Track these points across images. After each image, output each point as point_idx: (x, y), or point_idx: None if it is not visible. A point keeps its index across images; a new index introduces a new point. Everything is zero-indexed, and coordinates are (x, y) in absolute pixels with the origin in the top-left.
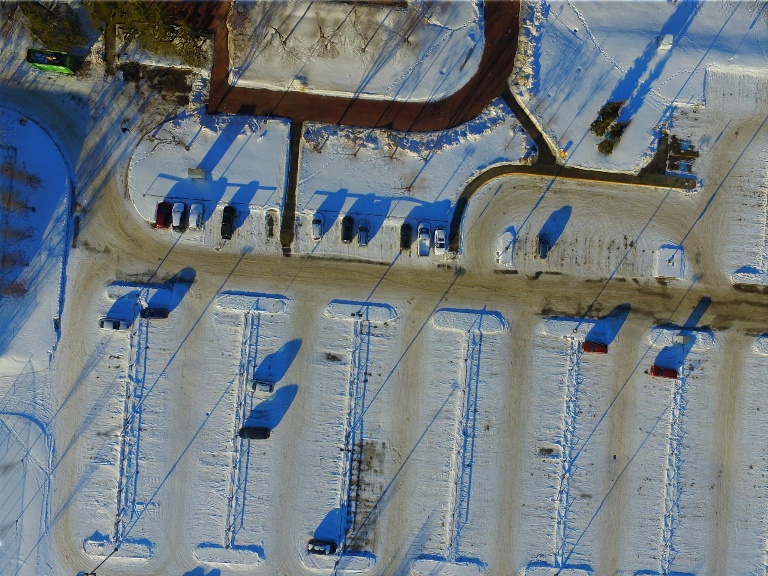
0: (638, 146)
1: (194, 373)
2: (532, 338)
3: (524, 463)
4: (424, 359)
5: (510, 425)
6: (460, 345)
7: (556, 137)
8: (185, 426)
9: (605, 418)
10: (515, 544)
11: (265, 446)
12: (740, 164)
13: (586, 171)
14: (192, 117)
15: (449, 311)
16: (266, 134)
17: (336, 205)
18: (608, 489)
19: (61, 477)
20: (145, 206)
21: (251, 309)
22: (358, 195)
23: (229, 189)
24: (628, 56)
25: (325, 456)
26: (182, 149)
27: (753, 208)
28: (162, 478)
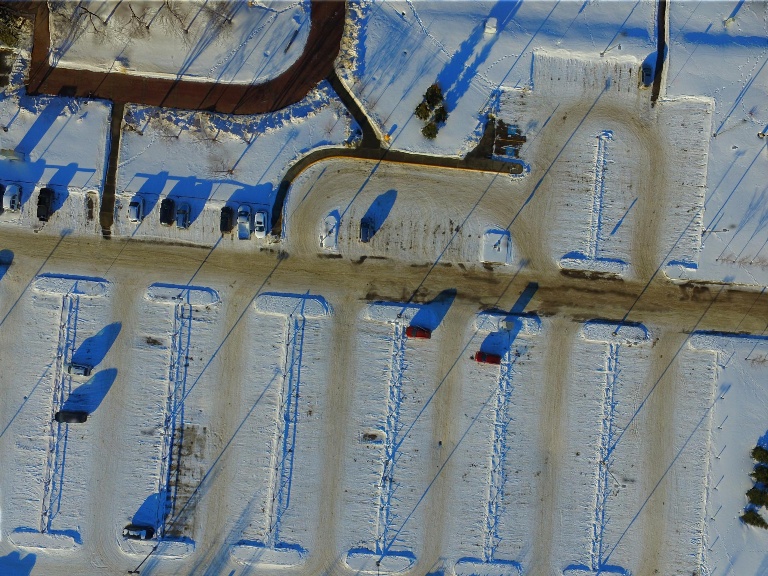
0: (463, 130)
1: (11, 356)
2: (356, 323)
3: (347, 449)
4: (246, 343)
5: (333, 410)
6: (282, 329)
7: (380, 120)
8: (2, 410)
9: (430, 404)
10: (336, 530)
11: (83, 430)
12: (568, 149)
13: (411, 155)
14: (11, 98)
15: (271, 295)
16: (86, 116)
17: (156, 187)
18: (433, 475)
19: None
20: None
21: (69, 292)
22: (179, 178)
23: (47, 171)
24: (455, 39)
25: (145, 441)
26: (0, 130)
27: (581, 193)
28: None
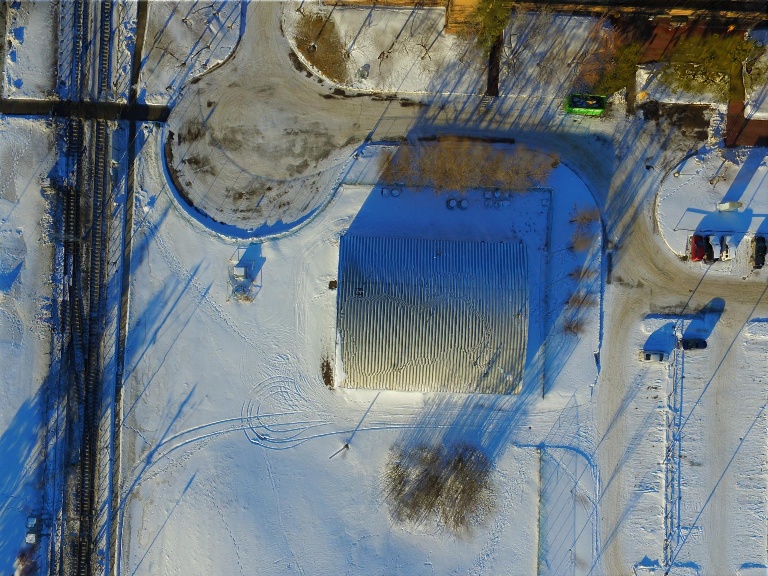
0: None
1: (727, 400)
2: None
3: None
4: None
5: None
6: None
7: None
8: (721, 451)
9: None
10: None
11: None
12: None
13: None
14: (714, 151)
15: None
16: None
17: None
18: None
19: (607, 506)
20: (676, 240)
21: None
22: None
23: (755, 220)
24: None
25: None
26: (707, 183)
27: None
28: (703, 503)
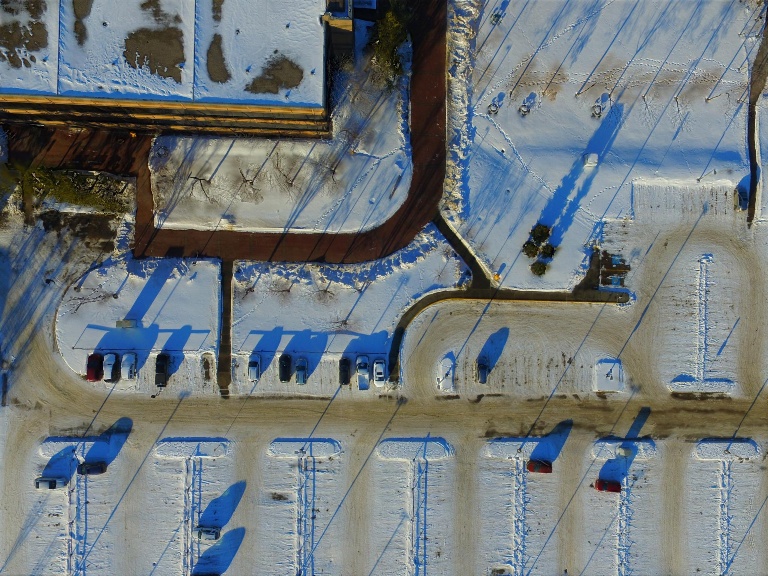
0: (570, 264)
1: (137, 524)
2: (477, 461)
3: None
4: (371, 491)
5: (461, 549)
6: (406, 474)
7: (489, 260)
8: None
9: (554, 534)
10: None
11: None
12: (671, 274)
13: (521, 292)
14: (118, 264)
15: (393, 441)
16: (196, 276)
17: (272, 344)
18: None
19: None
20: (75, 359)
21: (192, 455)
22: (294, 332)
23: (161, 335)
24: (556, 175)
25: None
26: (110, 298)
27: (686, 317)
28: None
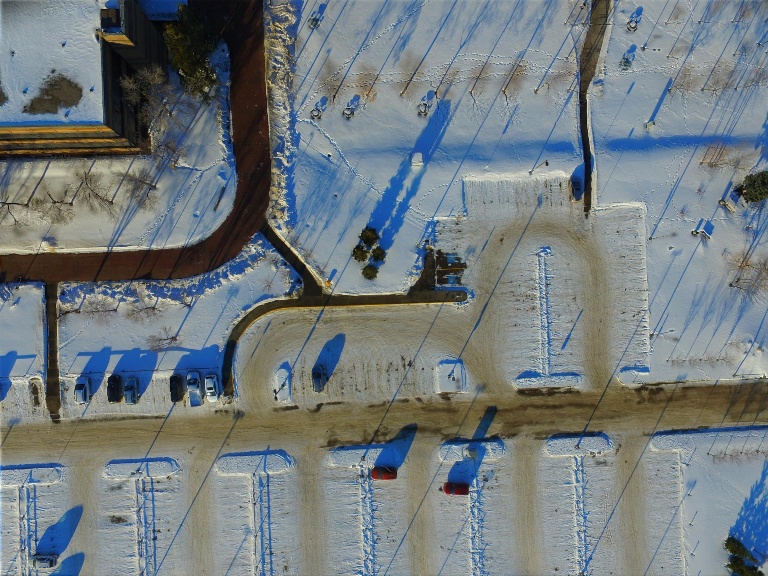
0: (403, 266)
1: None
2: (321, 471)
3: None
4: (212, 508)
5: (308, 562)
6: (247, 489)
7: (319, 267)
8: None
9: (404, 541)
10: None
11: None
12: (509, 270)
13: (354, 297)
14: None
15: (232, 456)
16: (19, 301)
17: (101, 365)
18: None
19: None
20: None
21: (25, 483)
22: (123, 351)
23: None
24: (383, 176)
25: None
26: None
27: (527, 312)
28: None
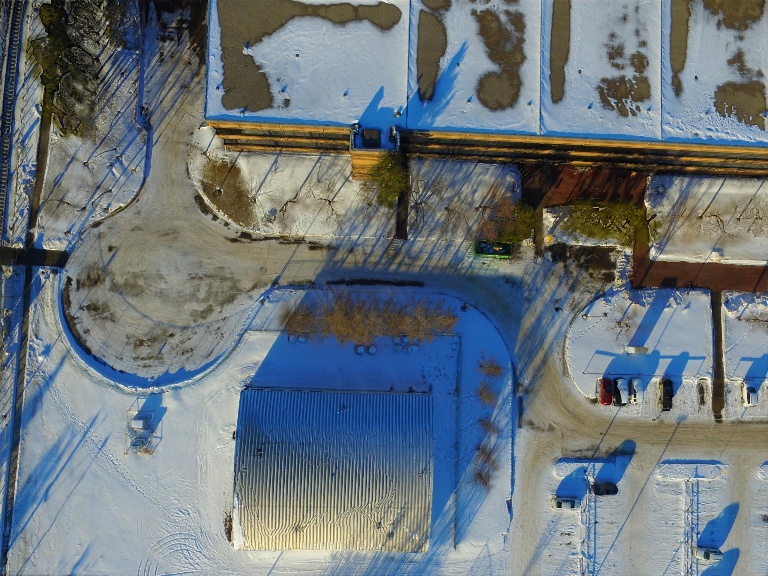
0: None
1: (641, 544)
2: None
3: None
4: None
5: None
6: None
7: None
8: None
9: None
10: None
11: None
12: None
13: None
14: (621, 293)
15: None
16: (690, 305)
17: (762, 370)
18: None
19: None
20: (585, 383)
21: (691, 477)
22: None
23: (662, 361)
24: None
25: None
26: None
27: None
28: None
